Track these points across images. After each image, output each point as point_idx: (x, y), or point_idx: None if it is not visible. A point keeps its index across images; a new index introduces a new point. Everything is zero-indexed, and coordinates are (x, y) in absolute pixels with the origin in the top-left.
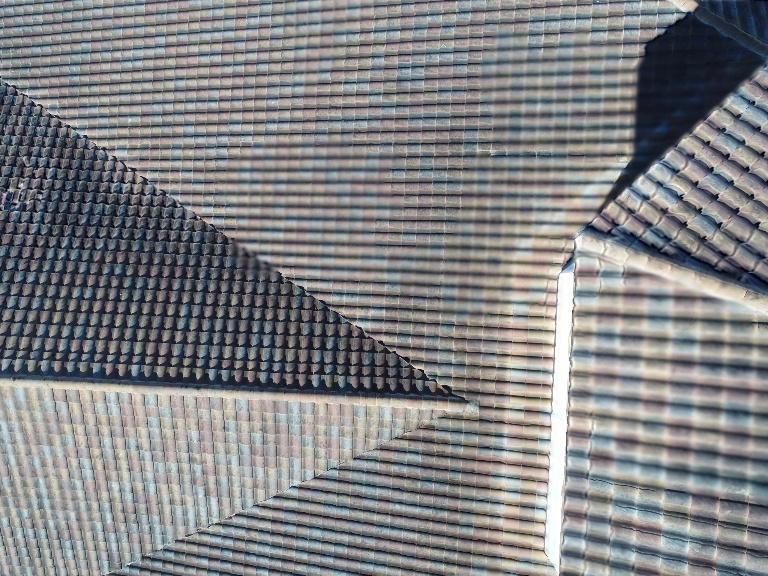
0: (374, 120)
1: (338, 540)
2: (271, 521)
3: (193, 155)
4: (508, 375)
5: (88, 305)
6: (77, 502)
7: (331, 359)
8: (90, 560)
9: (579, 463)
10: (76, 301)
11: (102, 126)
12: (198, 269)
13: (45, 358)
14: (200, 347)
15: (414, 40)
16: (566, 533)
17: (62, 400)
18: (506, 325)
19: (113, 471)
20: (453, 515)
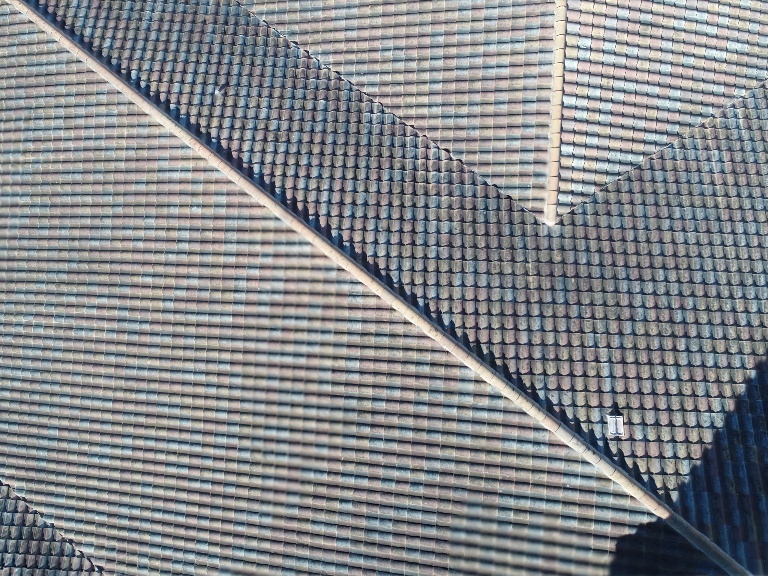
0: (342, 566)
1: None
2: None
3: (160, 566)
4: None
5: None
6: None
7: None
8: None
9: None
10: None
11: (69, 517)
12: None
13: None
14: None
15: (382, 490)
16: None
17: None
18: None
19: None
20: None
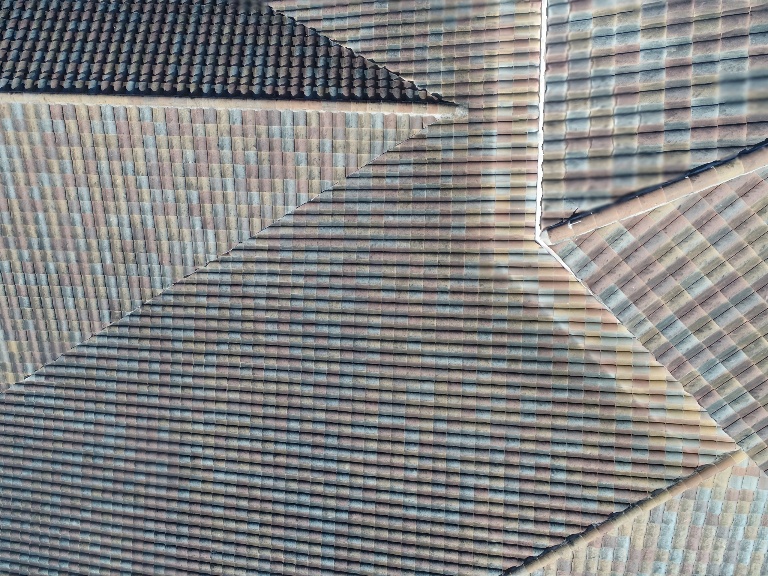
0: None
1: (333, 260)
2: (267, 250)
3: None
4: (496, 74)
5: (82, 35)
6: (76, 241)
7: (322, 74)
8: (91, 311)
9: (559, 9)
10: (71, 32)
11: None
12: (190, 6)
13: (41, 78)
14: (193, 67)
15: None
16: (548, 81)
17: (59, 117)
18: (493, 26)
19: (111, 201)
20: (445, 218)
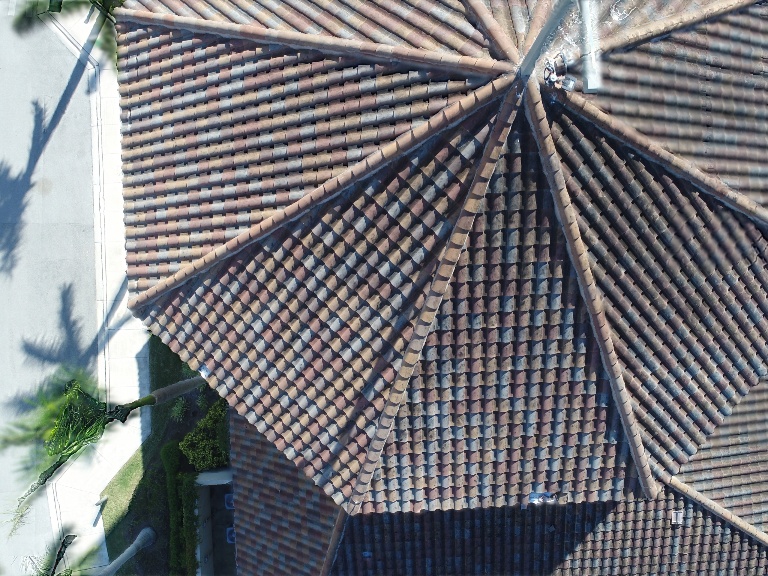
0: None
1: None
2: None
3: None
4: None
5: None
6: None
7: None
8: None
9: None
10: None
11: None
12: None
13: None
14: None
15: None
16: None
17: None
18: None
19: None
20: None
